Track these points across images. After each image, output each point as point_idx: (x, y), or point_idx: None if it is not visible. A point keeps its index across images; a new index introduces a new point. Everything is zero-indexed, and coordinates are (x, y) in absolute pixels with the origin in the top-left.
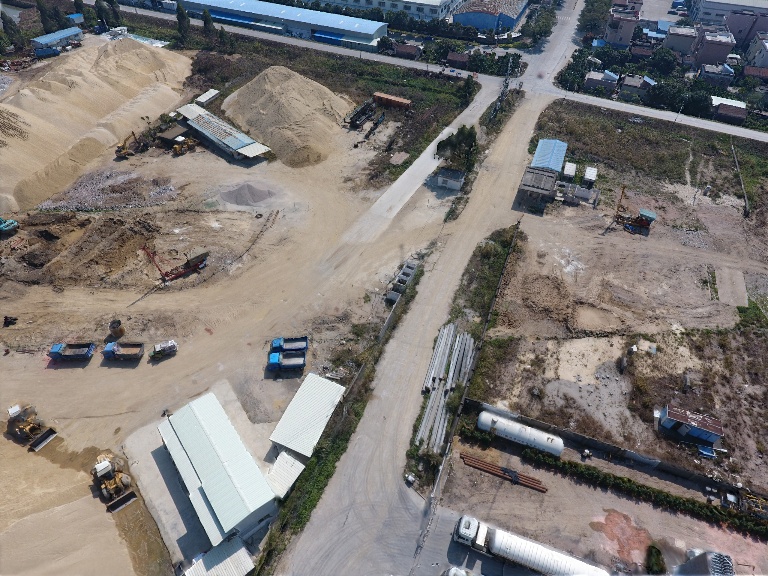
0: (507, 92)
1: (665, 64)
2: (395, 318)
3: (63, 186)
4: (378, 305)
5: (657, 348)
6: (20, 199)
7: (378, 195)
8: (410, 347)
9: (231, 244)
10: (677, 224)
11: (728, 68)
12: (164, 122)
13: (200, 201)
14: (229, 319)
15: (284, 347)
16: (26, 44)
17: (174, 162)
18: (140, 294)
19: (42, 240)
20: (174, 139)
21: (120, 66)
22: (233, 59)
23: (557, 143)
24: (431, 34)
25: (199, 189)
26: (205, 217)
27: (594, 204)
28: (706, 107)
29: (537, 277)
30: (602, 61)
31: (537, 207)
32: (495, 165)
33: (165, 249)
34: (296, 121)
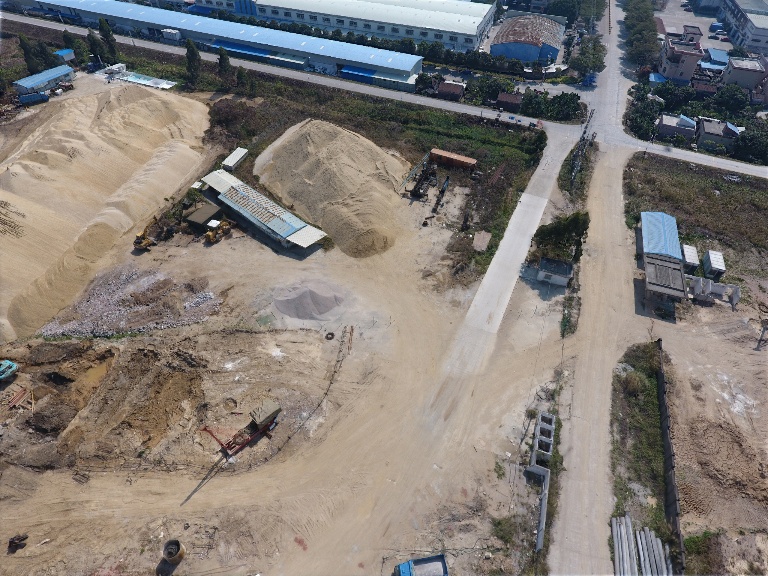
0: (578, 144)
1: (736, 103)
2: (552, 512)
3: (71, 297)
4: (517, 482)
5: None
6: (17, 323)
7: (469, 297)
8: (580, 559)
9: (303, 384)
10: None
11: None
12: (191, 200)
13: (251, 314)
14: (324, 519)
15: (415, 575)
16: (7, 86)
17: (208, 254)
18: (196, 480)
19: (51, 388)
20: (206, 223)
21: (128, 123)
22: (255, 104)
23: (665, 218)
24: (468, 67)
25: (246, 295)
26: (261, 340)
27: (731, 303)
28: None
29: (707, 426)
30: (664, 99)
31: (665, 309)
32: (596, 247)
33: (219, 398)
34: (351, 194)
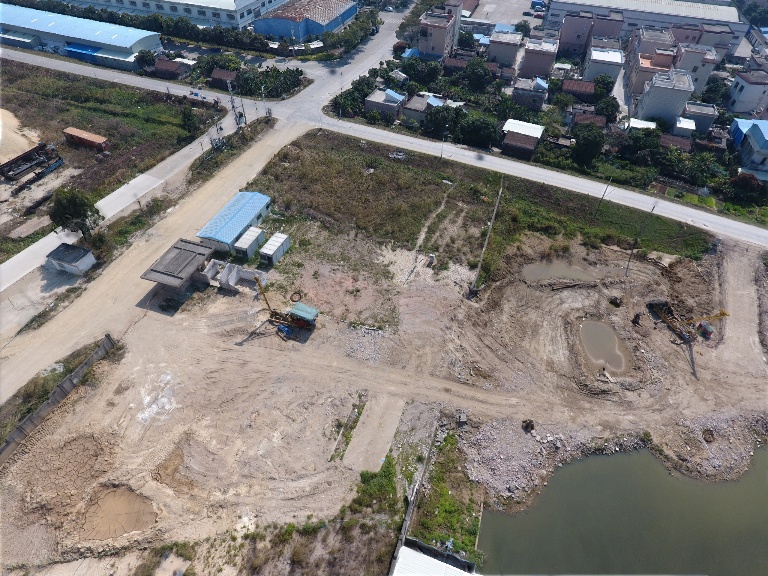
0: (253, 121)
1: (475, 78)
2: None
3: None
4: None
5: (183, 575)
6: None
7: None
8: None
9: None
10: (360, 318)
11: (540, 83)
12: None
13: None
14: None
15: None
16: None
17: None
18: None
19: None
20: None
21: None
22: None
23: (253, 198)
24: None
25: None
26: None
27: None
28: (488, 136)
29: (76, 437)
30: (408, 75)
31: (176, 300)
32: (164, 231)
33: None
34: None
